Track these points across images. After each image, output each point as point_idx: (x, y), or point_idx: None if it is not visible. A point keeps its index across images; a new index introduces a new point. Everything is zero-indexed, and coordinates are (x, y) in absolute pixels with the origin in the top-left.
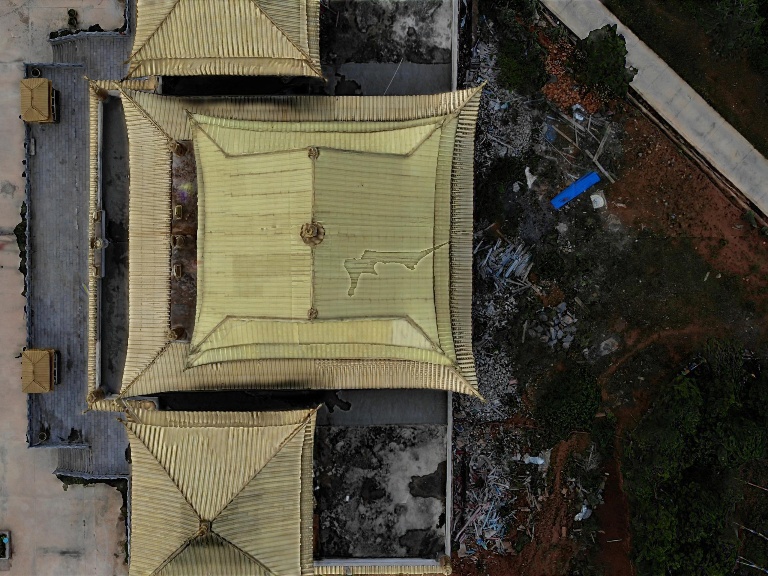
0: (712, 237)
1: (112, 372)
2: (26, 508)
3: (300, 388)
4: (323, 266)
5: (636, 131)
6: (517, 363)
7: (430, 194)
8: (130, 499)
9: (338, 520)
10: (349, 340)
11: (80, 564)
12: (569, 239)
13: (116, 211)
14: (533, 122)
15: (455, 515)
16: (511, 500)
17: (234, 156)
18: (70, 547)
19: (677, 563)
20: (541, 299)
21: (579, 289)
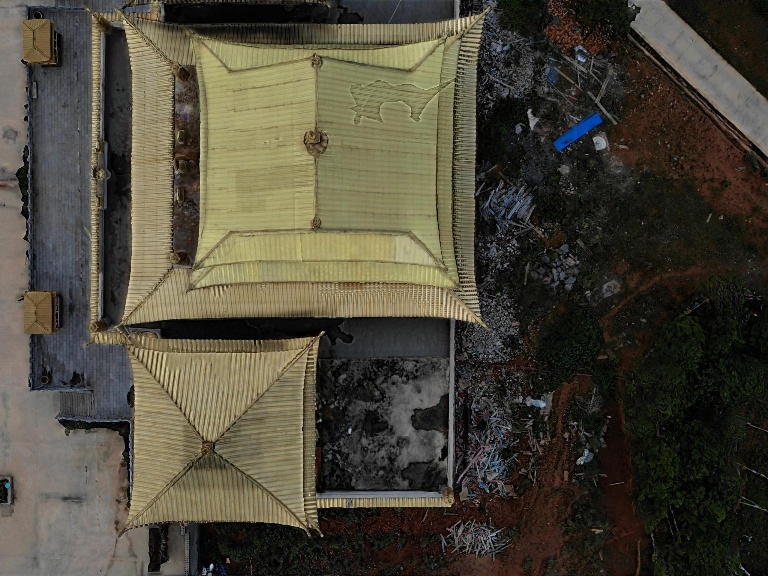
0: (714, 179)
1: (114, 304)
2: (28, 454)
3: (303, 316)
4: (326, 176)
5: (638, 73)
6: (519, 305)
7: (433, 111)
8: (132, 442)
9: (340, 453)
10: (352, 257)
11: (82, 510)
12: (571, 181)
13: (118, 143)
14: (535, 63)
15: (457, 458)
16: (513, 443)
17: (237, 71)
18: (72, 493)
19: (679, 500)
20: (543, 241)
21: (581, 231)
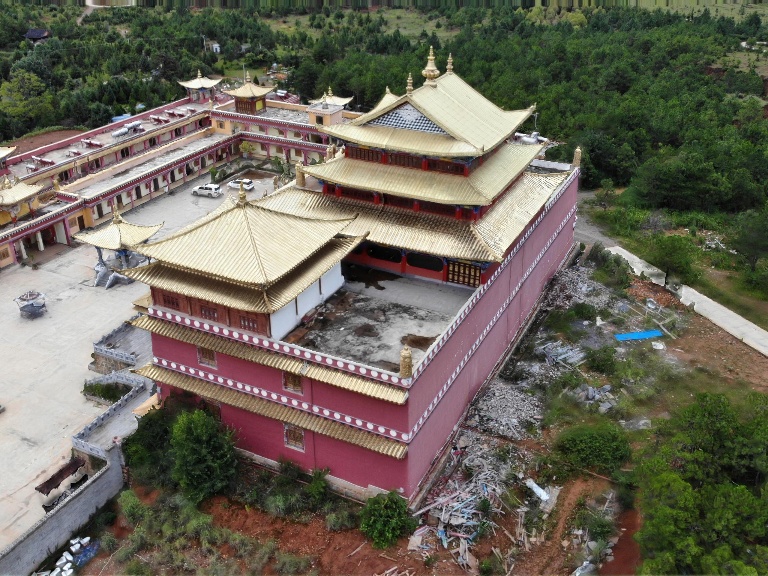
0: None
1: None
2: (35, 401)
3: None
4: (427, 92)
5: (701, 323)
6: (547, 408)
7: (510, 128)
8: (130, 398)
9: (323, 338)
10: (420, 149)
11: (28, 451)
12: (625, 358)
13: None
14: (611, 299)
15: (425, 504)
16: (496, 509)
17: None
18: (35, 438)
19: None
20: (587, 381)
21: (626, 383)
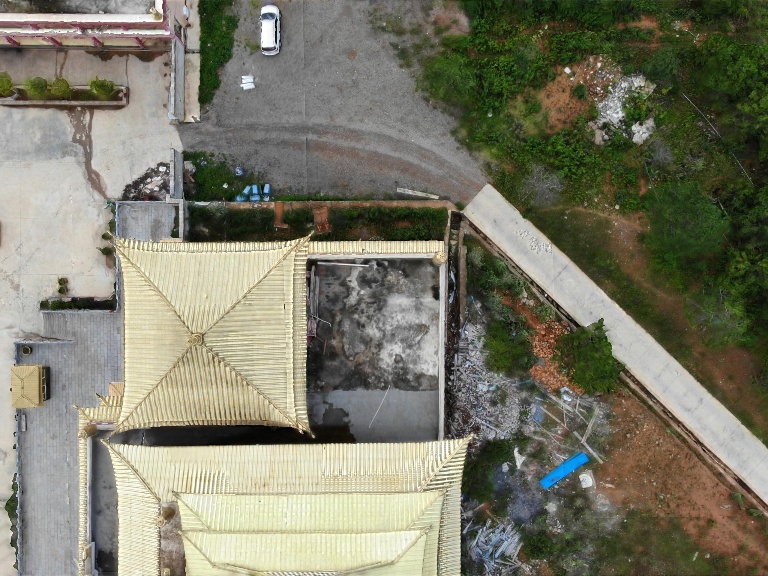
0: (700, 517)
1: None
2: None
3: None
4: None
5: (624, 411)
6: None
7: None
8: None
9: None
10: None
11: None
12: (558, 518)
13: (106, 541)
14: (521, 404)
15: None
16: None
17: (221, 569)
18: None
19: None
20: None
21: (569, 569)
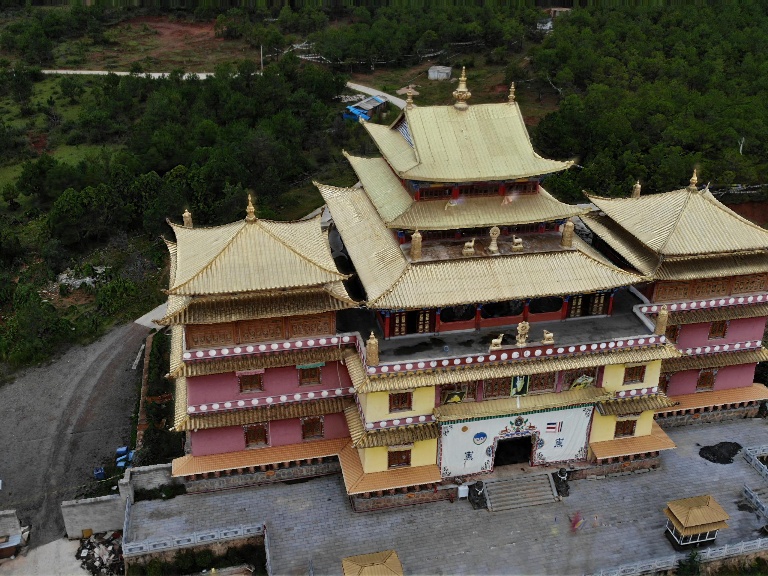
0: None
1: None
2: None
3: None
4: None
5: None
6: None
7: None
8: (766, 450)
9: None
10: None
11: None
12: None
13: None
14: None
15: None
16: None
17: (420, 158)
18: None
19: (569, 181)
20: None
21: None
